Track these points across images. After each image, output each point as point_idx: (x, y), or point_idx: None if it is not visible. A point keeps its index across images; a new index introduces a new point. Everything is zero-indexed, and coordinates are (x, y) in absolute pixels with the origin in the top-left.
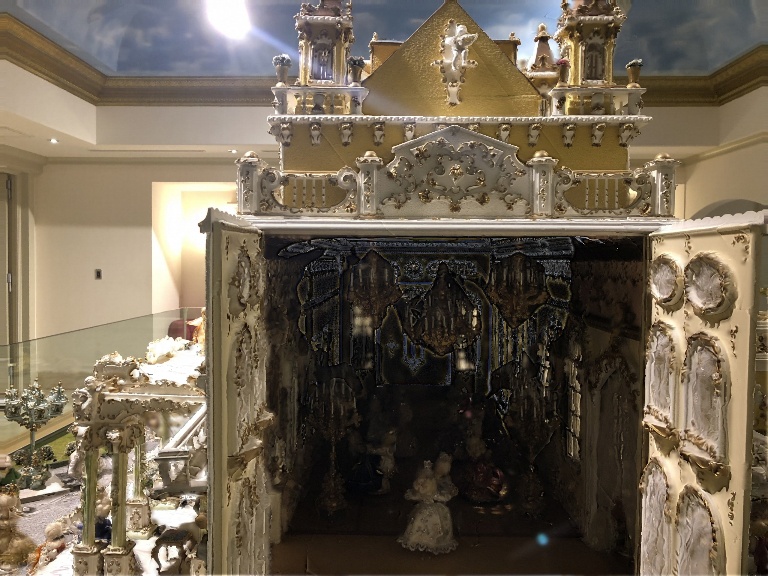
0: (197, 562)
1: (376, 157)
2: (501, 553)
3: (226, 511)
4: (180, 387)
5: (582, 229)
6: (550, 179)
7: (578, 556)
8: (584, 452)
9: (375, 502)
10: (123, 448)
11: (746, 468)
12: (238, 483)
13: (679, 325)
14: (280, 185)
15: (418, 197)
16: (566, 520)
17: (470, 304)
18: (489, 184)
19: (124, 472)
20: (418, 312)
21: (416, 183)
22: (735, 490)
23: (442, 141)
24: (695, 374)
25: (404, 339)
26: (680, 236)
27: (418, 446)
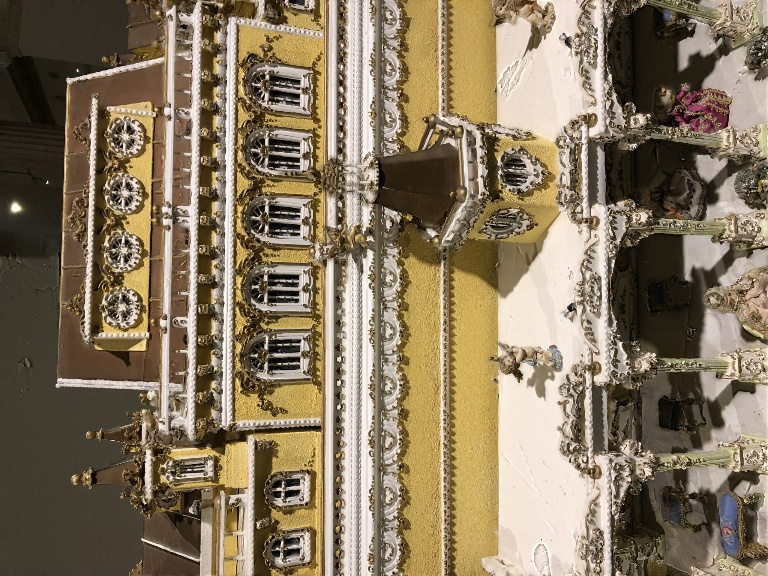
0: None
1: None
2: None
3: None
4: None
5: None
6: None
7: None
8: None
9: None
10: None
11: None
12: None
13: None
14: None
15: None
16: None
17: None
18: None
19: None
20: None
21: None
22: None
23: None
24: None
25: None
26: None
27: None
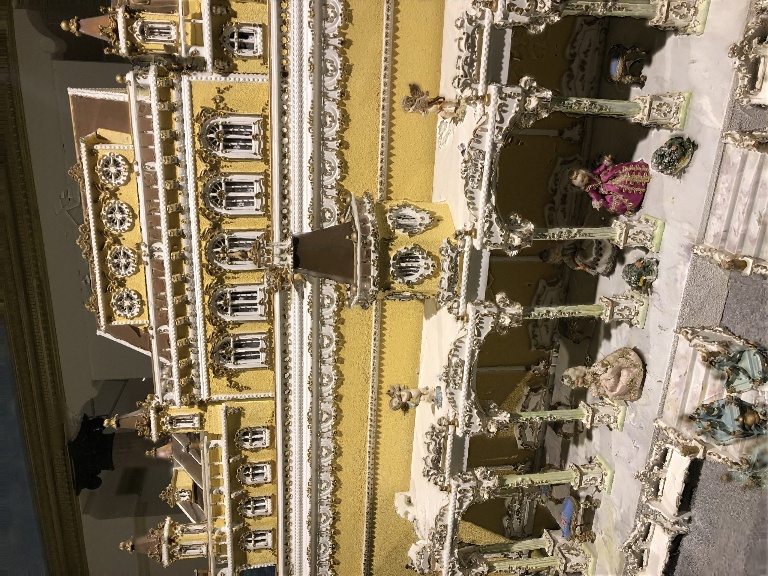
0: None
1: None
2: None
3: None
4: None
5: None
6: None
7: None
8: None
9: None
10: None
11: None
12: None
13: None
14: None
15: None
16: None
17: None
18: None
19: None
20: None
21: None
22: None
23: None
24: None
25: None
26: None
27: None
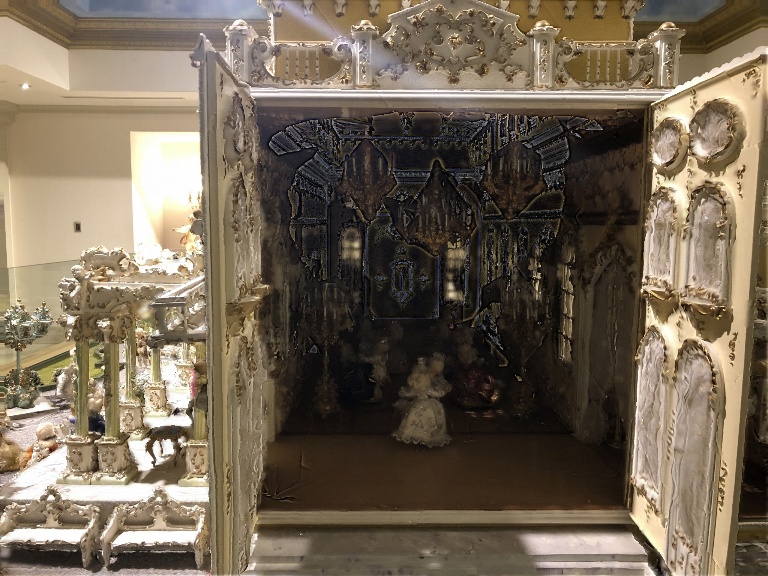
0: (192, 450)
1: (372, 25)
2: (494, 447)
3: (225, 358)
4: (171, 275)
5: (583, 99)
6: (551, 49)
7: (569, 449)
8: (576, 351)
9: (368, 408)
10: (114, 338)
11: (749, 305)
12: (236, 338)
13: (681, 187)
14: (272, 56)
15: (415, 68)
16: (557, 421)
17: (464, 203)
18: (488, 55)
19: (116, 363)
20: (411, 212)
21: (413, 53)
22: (737, 330)
23: (440, 8)
24: (697, 229)
25: (392, 272)
26: (685, 94)
27: (409, 363)
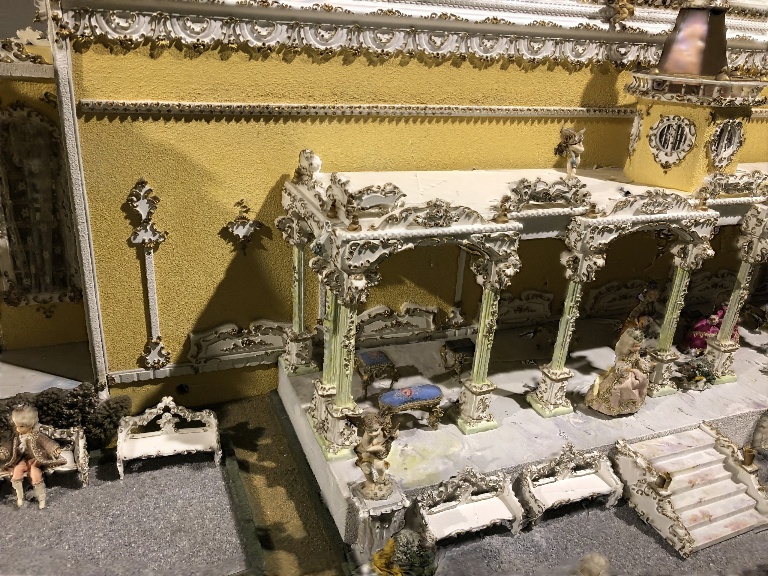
0: None
1: None
2: None
3: None
4: None
5: None
6: None
7: None
8: None
9: None
10: None
11: None
12: None
13: None
14: None
15: None
16: None
17: None
18: None
19: None
20: None
21: None
22: None
23: None
24: None
25: None
26: None
27: None
